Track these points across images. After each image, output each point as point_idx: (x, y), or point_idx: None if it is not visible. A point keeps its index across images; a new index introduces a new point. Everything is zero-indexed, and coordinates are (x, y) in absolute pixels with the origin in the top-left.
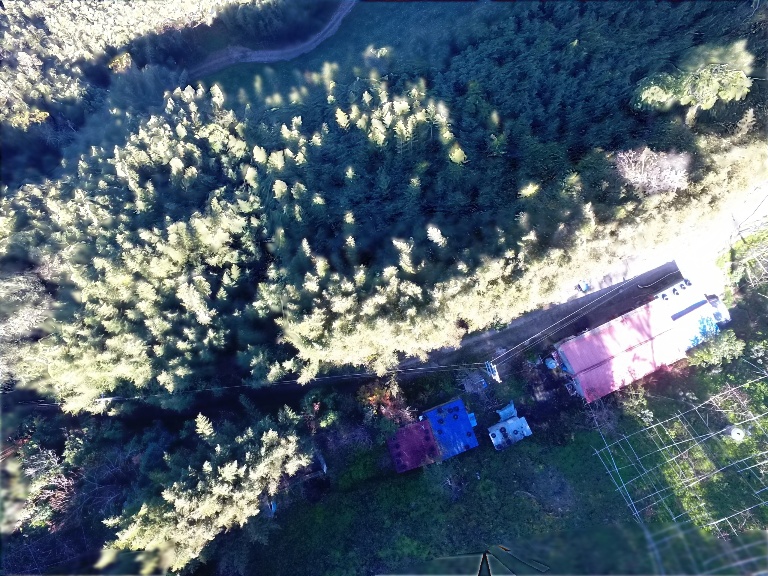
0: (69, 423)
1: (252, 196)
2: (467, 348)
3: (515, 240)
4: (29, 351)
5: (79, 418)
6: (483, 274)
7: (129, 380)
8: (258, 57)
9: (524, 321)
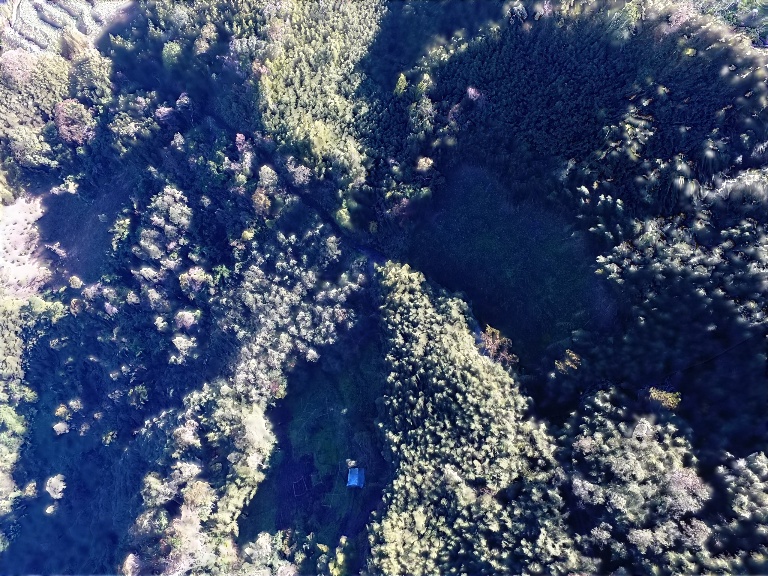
0: None
1: (704, 188)
2: None
3: None
4: None
5: None
6: None
7: None
8: None
9: None
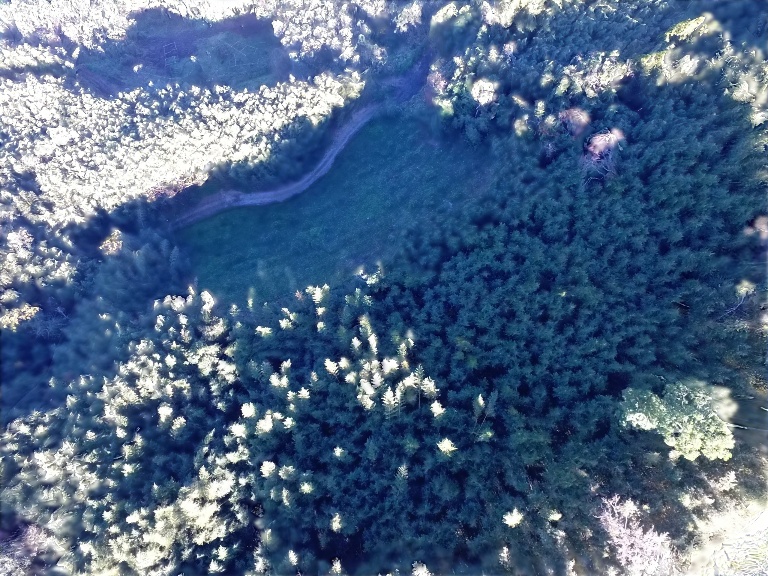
0: None
1: (241, 446)
2: None
3: None
4: None
5: None
6: None
7: None
8: (251, 200)
9: None
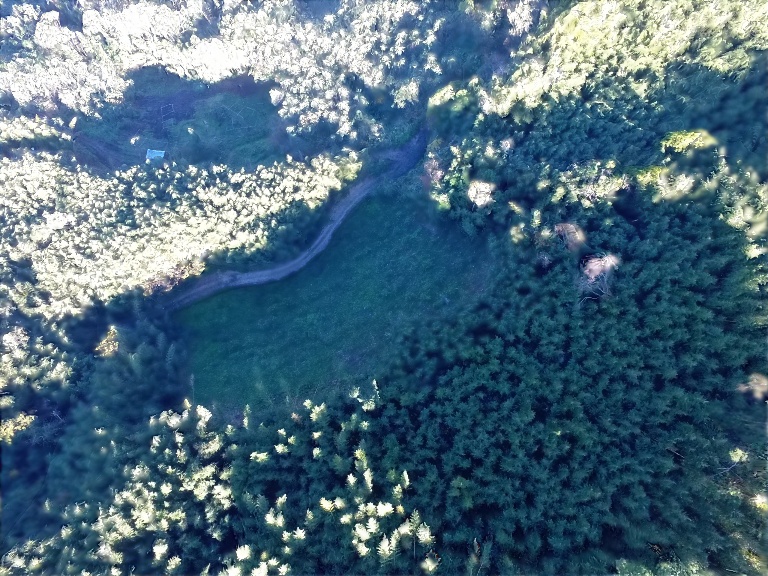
0: None
1: None
2: None
3: None
4: None
5: None
6: None
7: None
8: (248, 279)
9: None
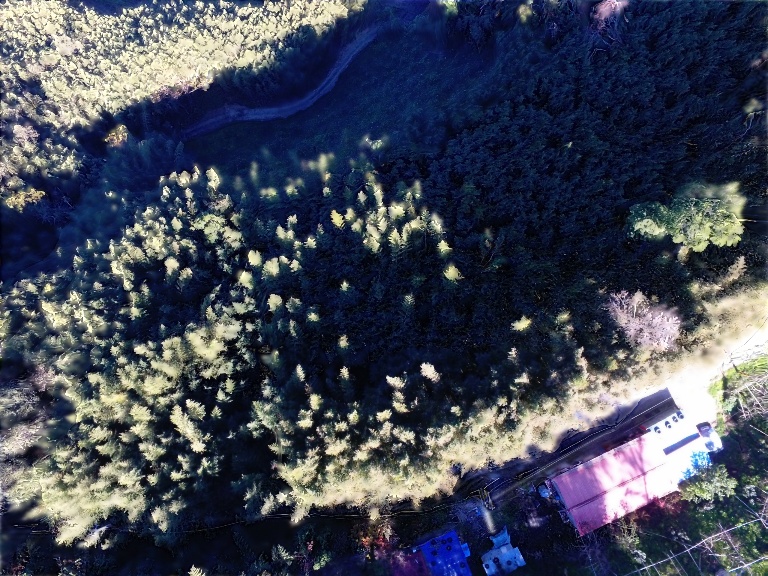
0: (63, 553)
1: (247, 297)
2: (460, 490)
3: (508, 383)
4: (23, 473)
5: (73, 549)
6: (476, 419)
7: (123, 510)
8: (255, 115)
9: (517, 463)
